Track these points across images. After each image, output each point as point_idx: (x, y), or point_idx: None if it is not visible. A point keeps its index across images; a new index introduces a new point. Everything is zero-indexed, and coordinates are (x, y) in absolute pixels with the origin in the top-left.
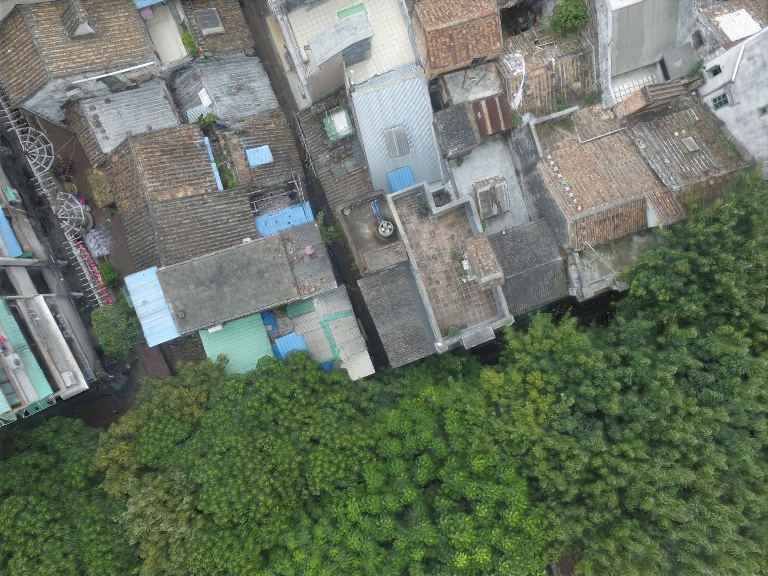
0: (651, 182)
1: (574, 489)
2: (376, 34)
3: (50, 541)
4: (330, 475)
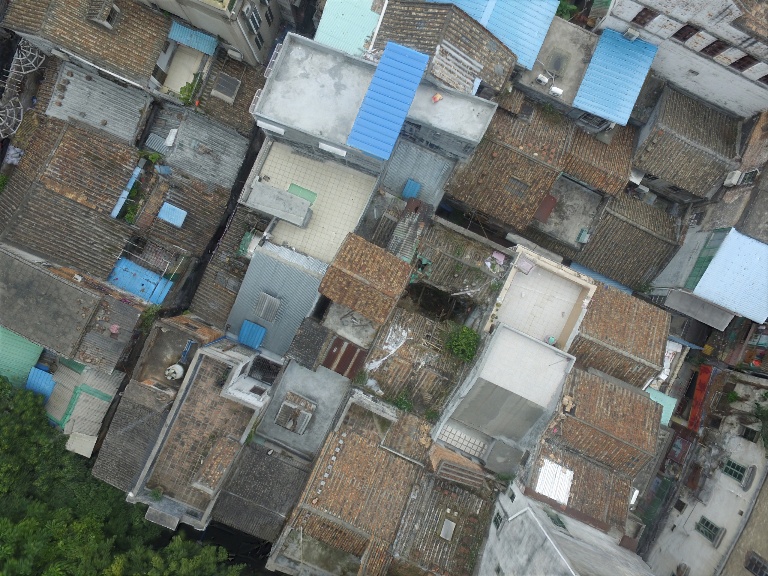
0: (389, 531)
1: None
2: (326, 216)
3: None
4: None
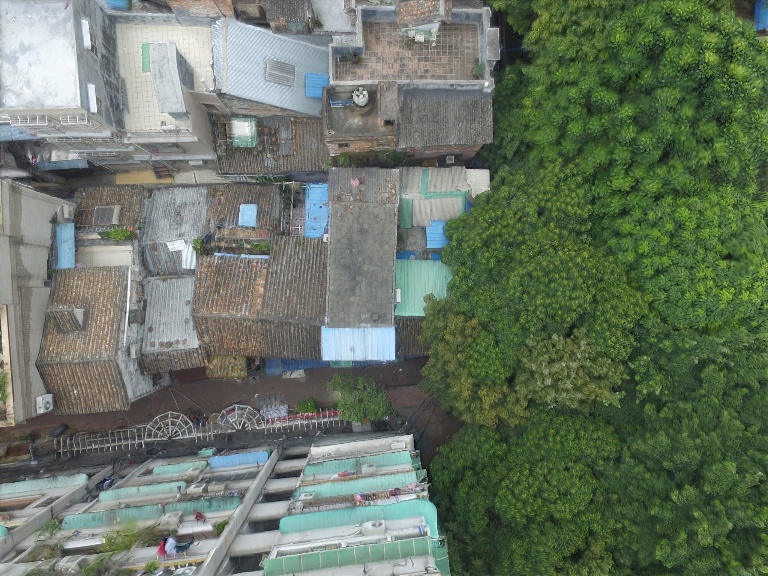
0: None
1: None
2: None
3: (549, 478)
4: (578, 200)
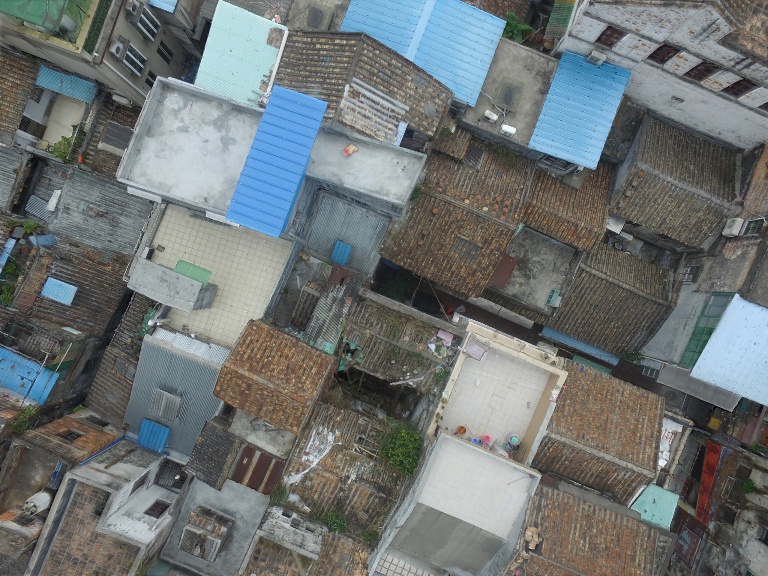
0: None
1: None
2: (235, 291)
3: None
4: None
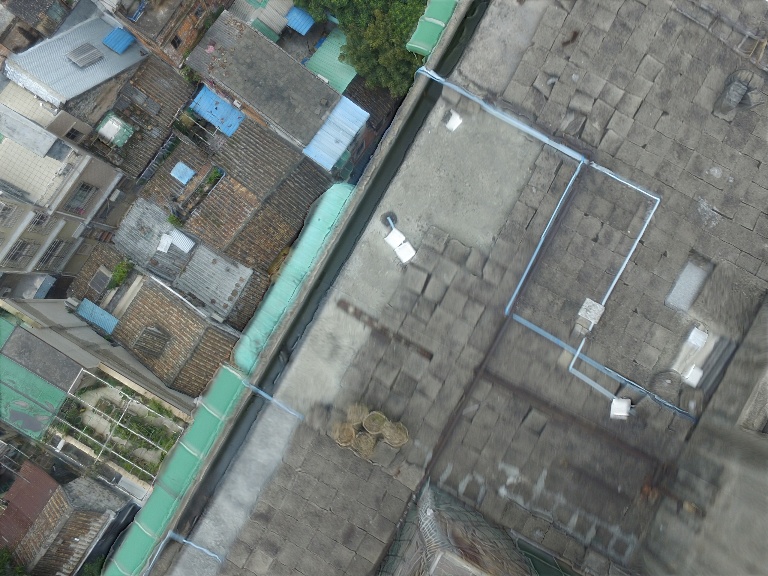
0: None
1: None
2: None
3: None
4: None
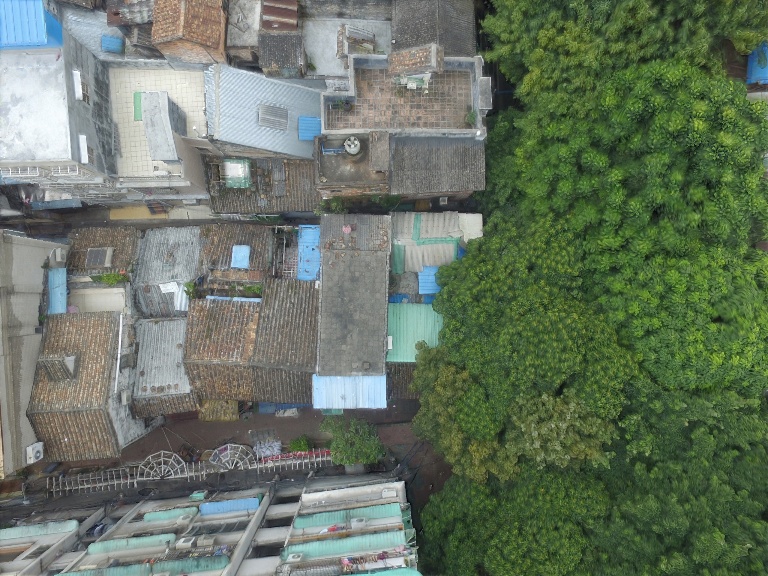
0: None
1: (664, 22)
2: None
3: (538, 537)
4: (568, 258)
